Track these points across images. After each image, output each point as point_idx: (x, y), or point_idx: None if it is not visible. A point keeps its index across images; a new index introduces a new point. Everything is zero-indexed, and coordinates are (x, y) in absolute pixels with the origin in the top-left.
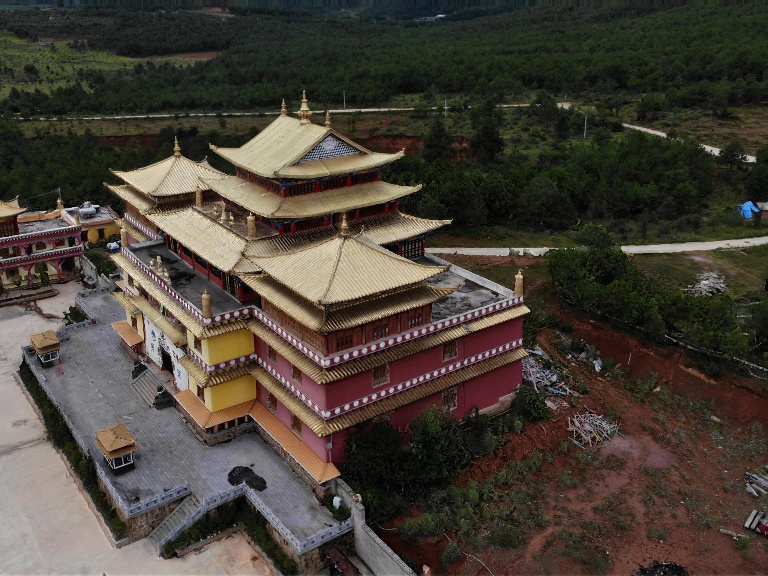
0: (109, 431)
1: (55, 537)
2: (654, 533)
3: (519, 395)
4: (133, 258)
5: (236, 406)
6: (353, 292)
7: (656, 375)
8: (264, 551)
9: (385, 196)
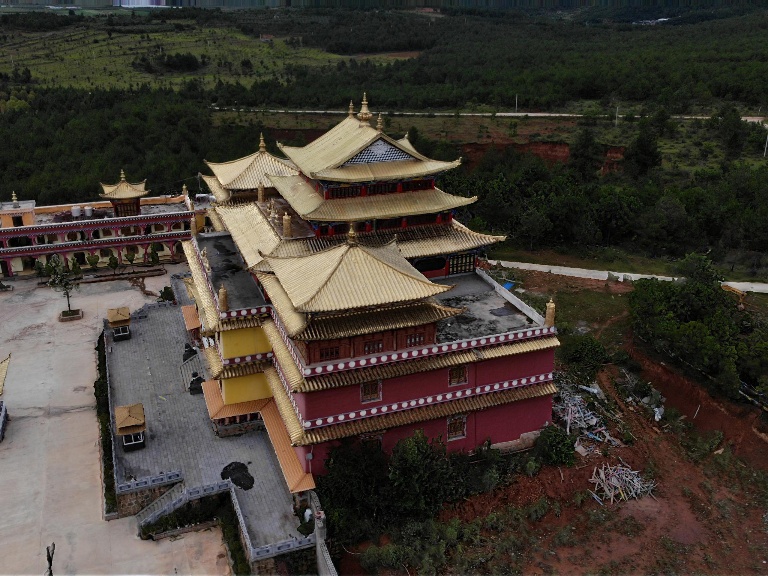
0: (126, 408)
1: (61, 499)
2: None
3: (542, 434)
4: (195, 247)
5: (250, 402)
6: (340, 303)
7: (720, 435)
8: (230, 550)
9: (435, 206)
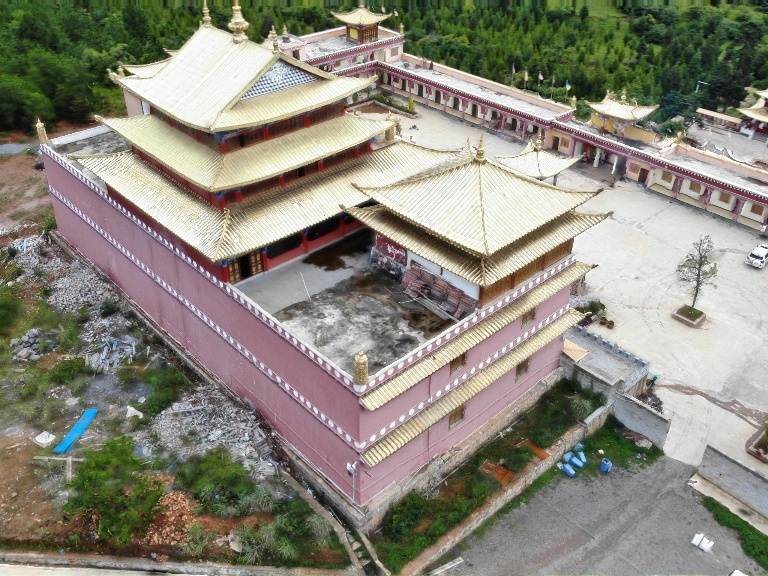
0: None
1: None
2: None
3: None
4: None
5: None
6: None
7: None
8: None
9: None
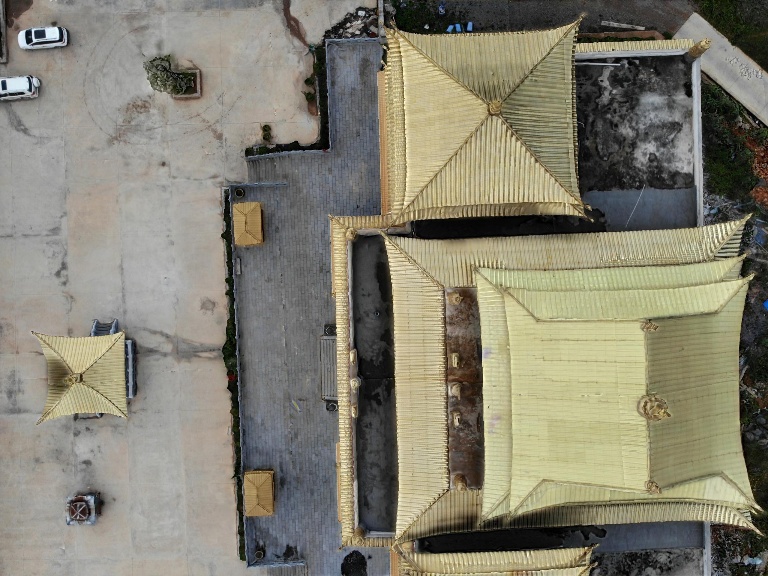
0: (255, 488)
1: (200, 513)
2: None
3: None
4: (348, 284)
5: None
6: None
7: None
8: None
9: None
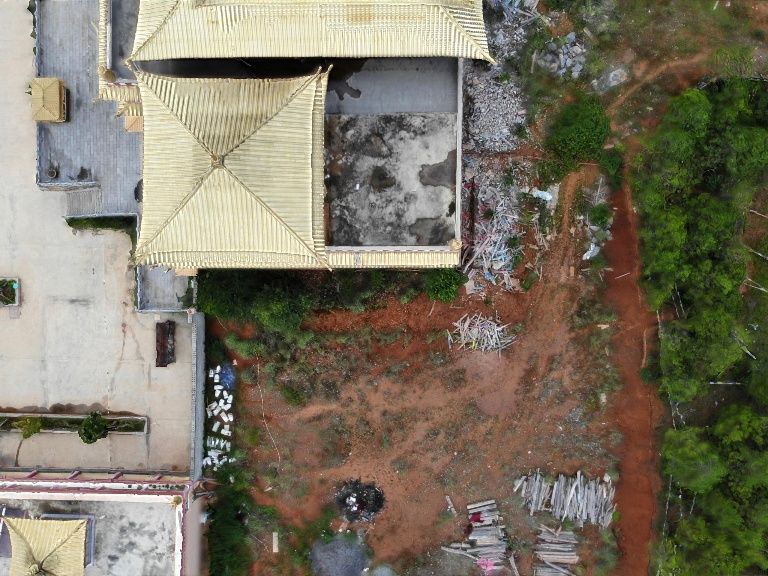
0: (41, 90)
1: (2, 144)
2: (400, 463)
3: (432, 274)
4: None
5: None
6: (188, 242)
7: (612, 320)
8: None
9: None
